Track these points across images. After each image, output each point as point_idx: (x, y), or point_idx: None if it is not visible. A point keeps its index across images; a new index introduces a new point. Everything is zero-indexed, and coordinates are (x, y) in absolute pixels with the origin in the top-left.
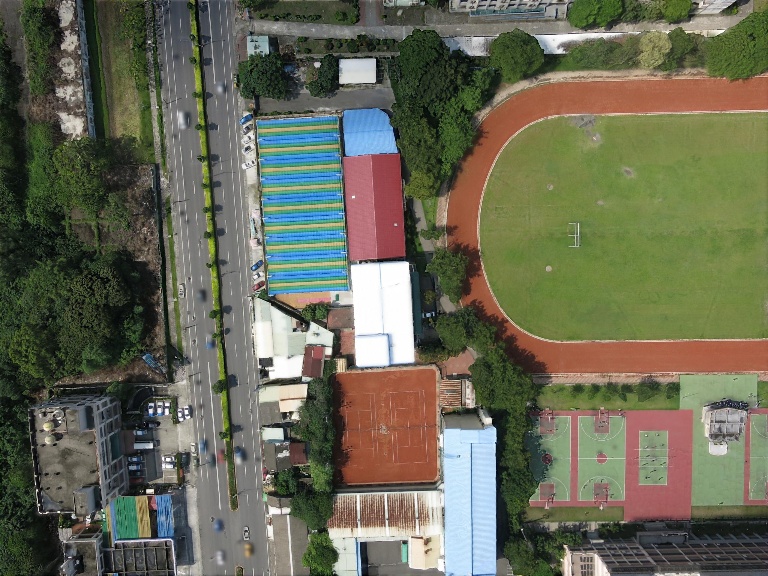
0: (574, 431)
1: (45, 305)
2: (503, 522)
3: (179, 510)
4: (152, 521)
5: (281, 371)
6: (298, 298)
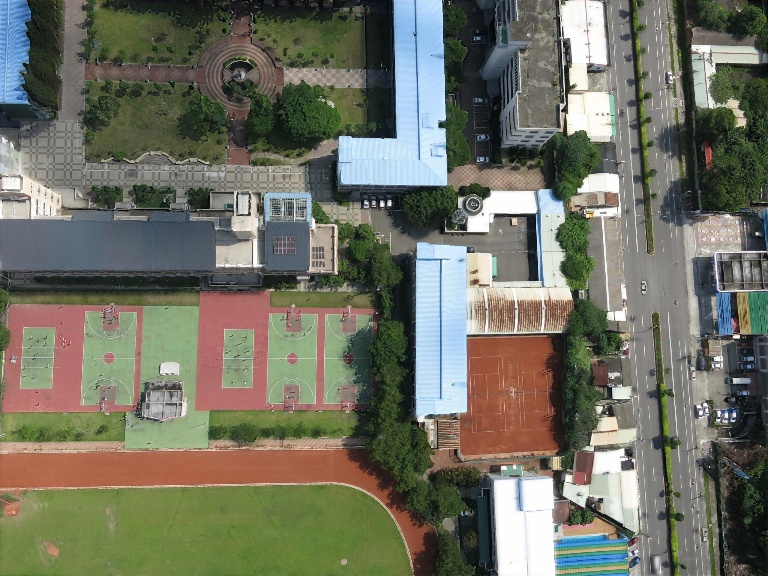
0: (320, 388)
1: None
2: (395, 295)
3: (707, 313)
4: (733, 305)
5: (615, 458)
6: (594, 528)
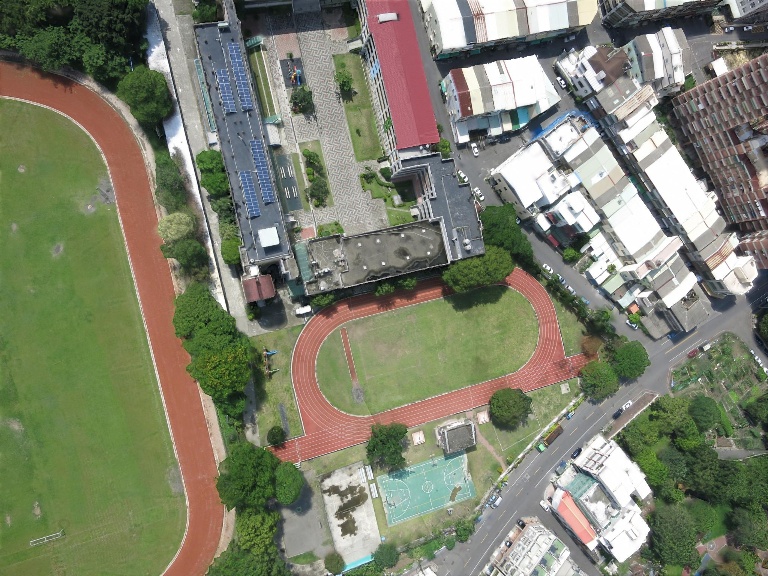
0: None
1: None
2: None
3: None
4: None
5: None
6: None
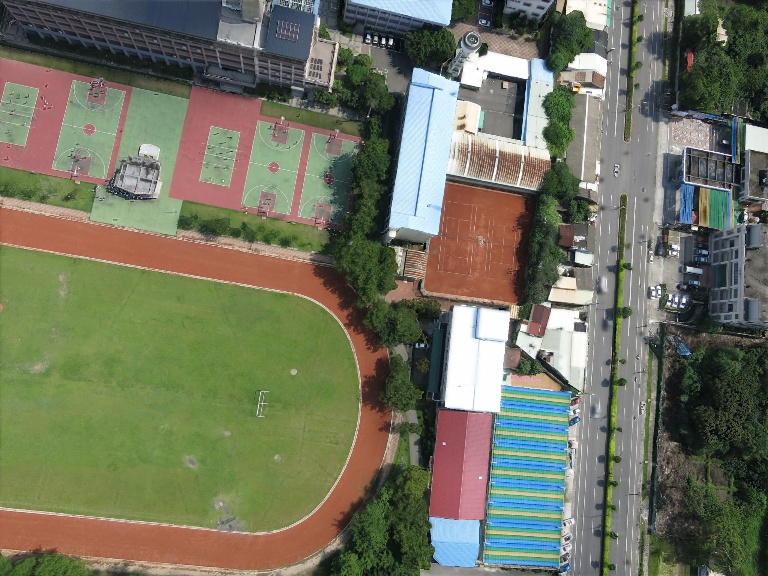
0: (297, 201)
1: (767, 418)
2: (383, 127)
3: (670, 205)
4: (695, 201)
5: (569, 317)
6: (541, 383)
